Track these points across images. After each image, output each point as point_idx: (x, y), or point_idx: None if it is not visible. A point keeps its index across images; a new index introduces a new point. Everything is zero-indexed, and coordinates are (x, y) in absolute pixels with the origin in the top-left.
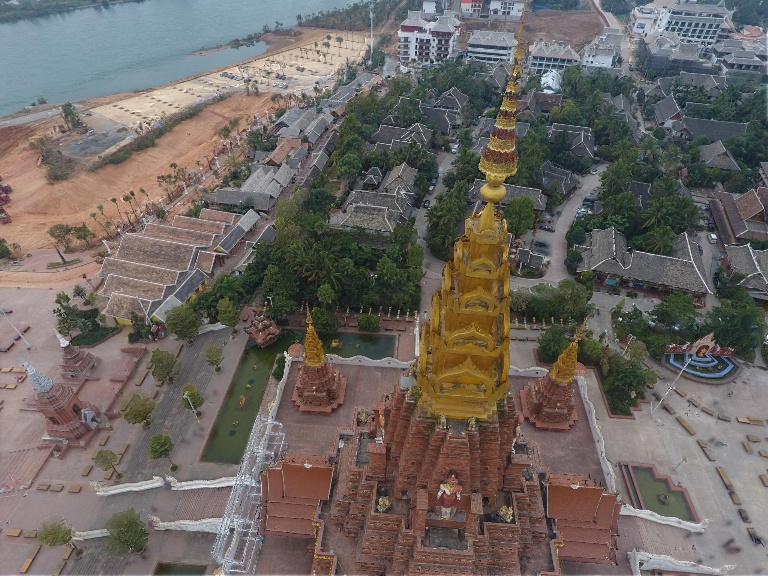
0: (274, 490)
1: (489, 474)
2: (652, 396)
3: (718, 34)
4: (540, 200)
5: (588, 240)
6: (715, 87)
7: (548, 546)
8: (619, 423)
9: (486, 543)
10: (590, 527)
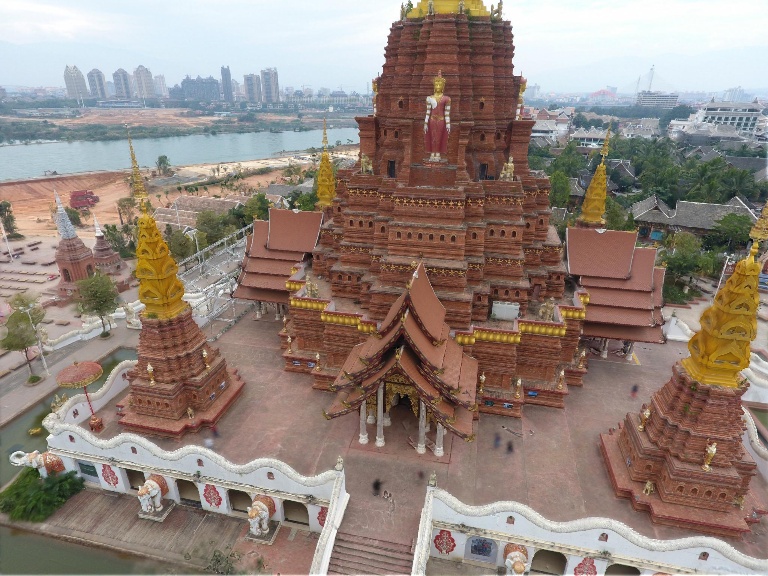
0: (257, 245)
1: (485, 115)
2: (711, 297)
3: (757, 125)
4: (577, 187)
5: (629, 211)
6: (758, 147)
7: (570, 301)
8: (670, 309)
9: (480, 193)
10: (624, 287)
